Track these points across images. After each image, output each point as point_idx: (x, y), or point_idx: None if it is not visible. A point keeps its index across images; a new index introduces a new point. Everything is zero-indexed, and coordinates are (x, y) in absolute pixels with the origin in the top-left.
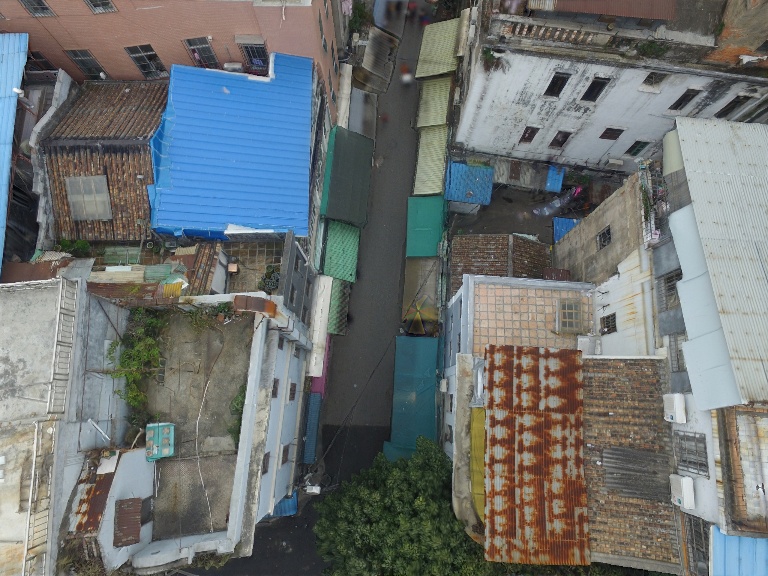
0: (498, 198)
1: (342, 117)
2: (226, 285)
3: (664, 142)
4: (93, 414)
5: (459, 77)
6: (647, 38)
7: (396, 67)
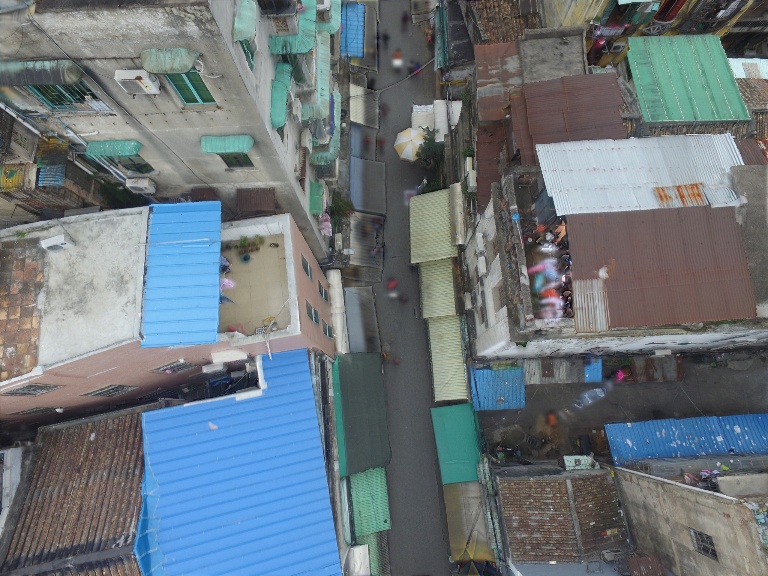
0: None
1: (341, 337)
2: None
3: None
4: None
5: (464, 270)
6: None
7: None
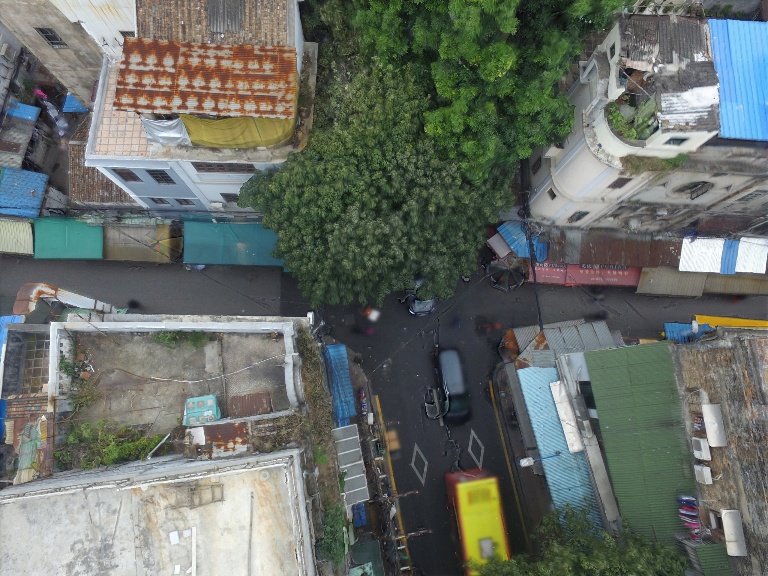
0: (53, 177)
1: None
2: None
3: None
4: None
5: None
6: None
7: None
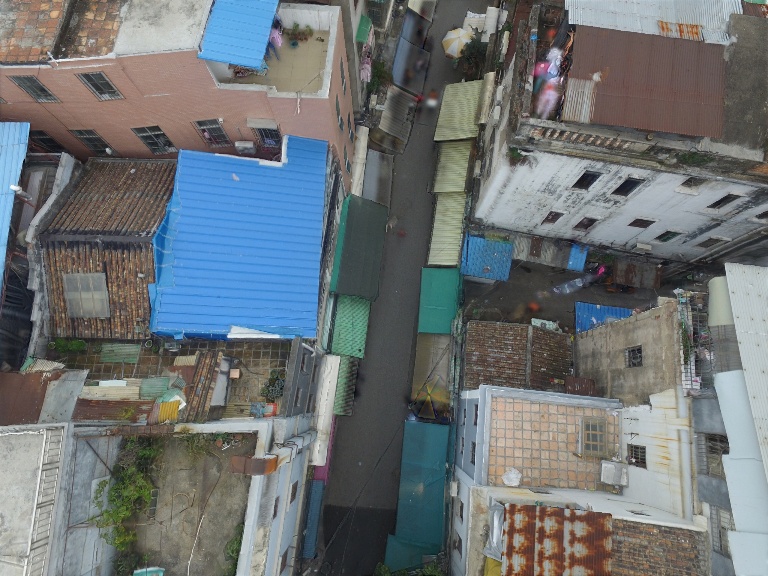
0: None
1: (356, 183)
2: (227, 391)
3: (710, 287)
4: (75, 571)
5: (480, 146)
6: (689, 150)
7: (414, 122)
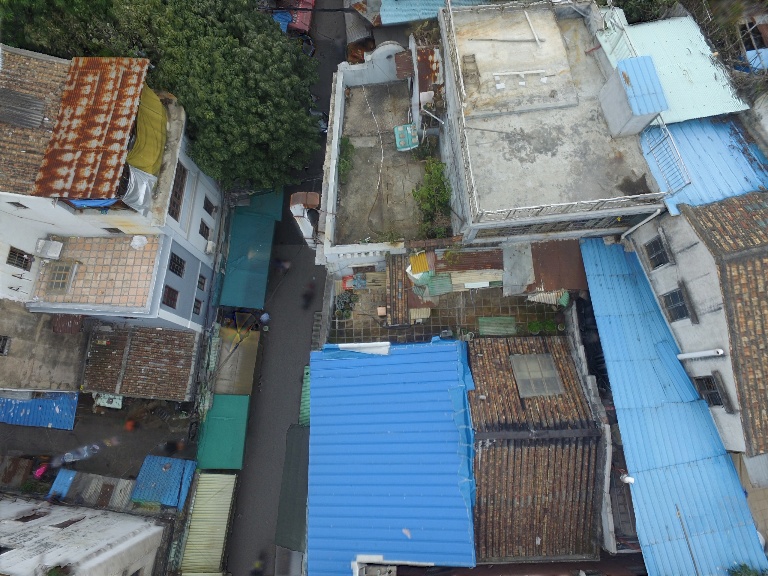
0: None
1: None
2: None
3: None
4: None
5: None
6: None
7: None
